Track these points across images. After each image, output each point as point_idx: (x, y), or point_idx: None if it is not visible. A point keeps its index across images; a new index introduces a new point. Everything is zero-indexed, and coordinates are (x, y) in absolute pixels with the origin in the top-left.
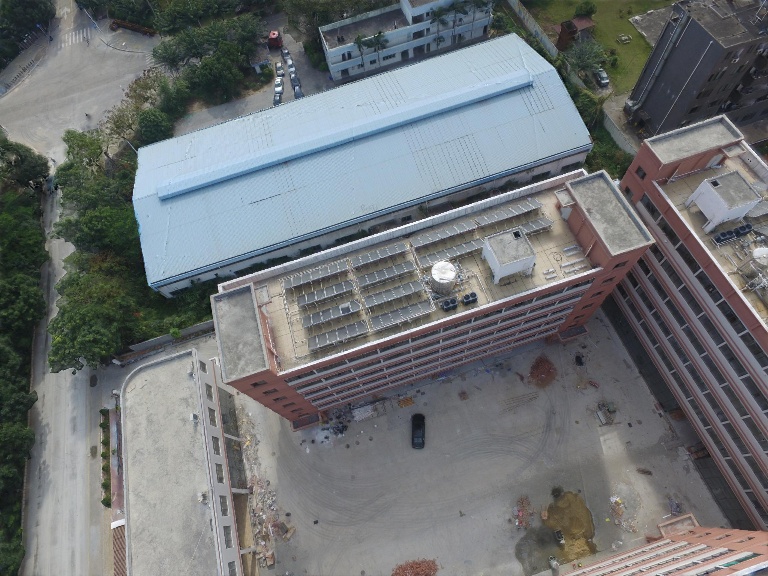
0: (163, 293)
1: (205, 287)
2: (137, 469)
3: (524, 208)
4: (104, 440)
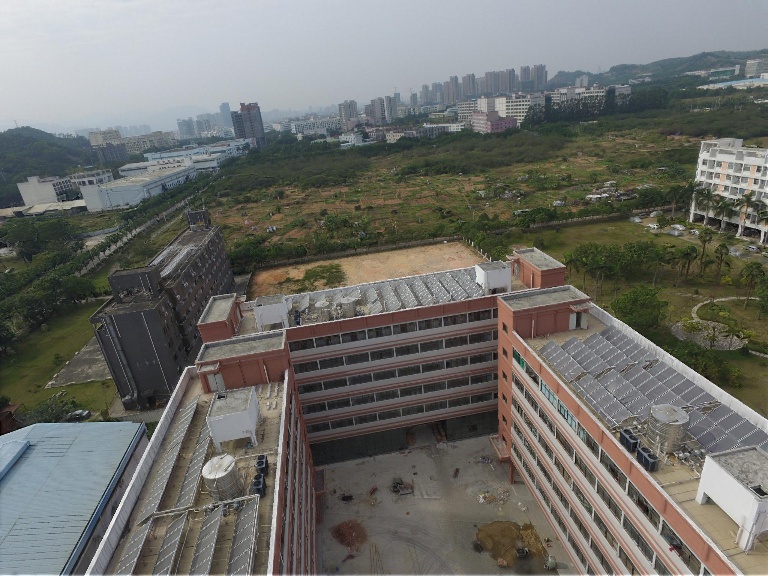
0: None
1: None
2: None
3: (190, 408)
4: None
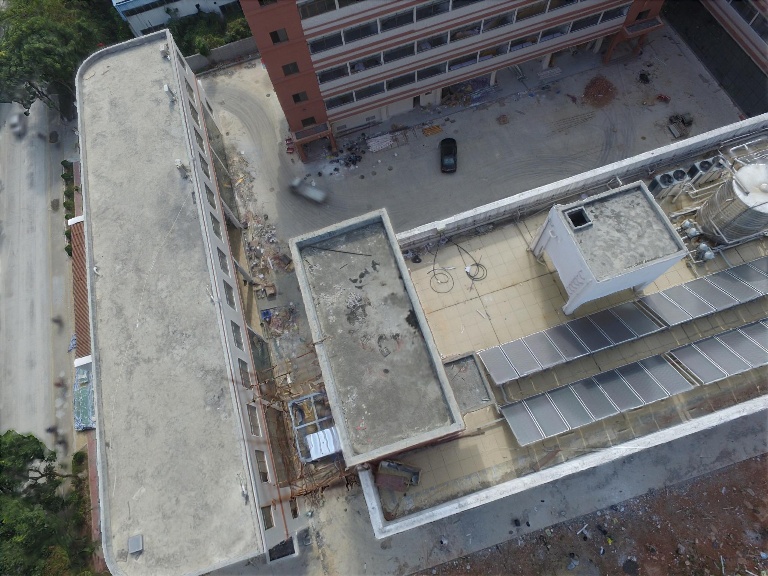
0: (133, 29)
1: (184, 20)
2: (98, 151)
3: None
4: (67, 190)
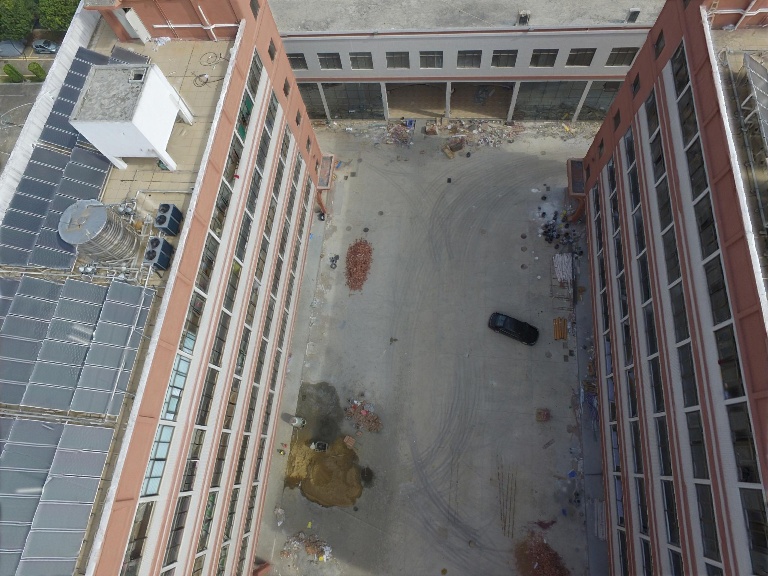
0: None
1: None
2: None
3: None
4: None
